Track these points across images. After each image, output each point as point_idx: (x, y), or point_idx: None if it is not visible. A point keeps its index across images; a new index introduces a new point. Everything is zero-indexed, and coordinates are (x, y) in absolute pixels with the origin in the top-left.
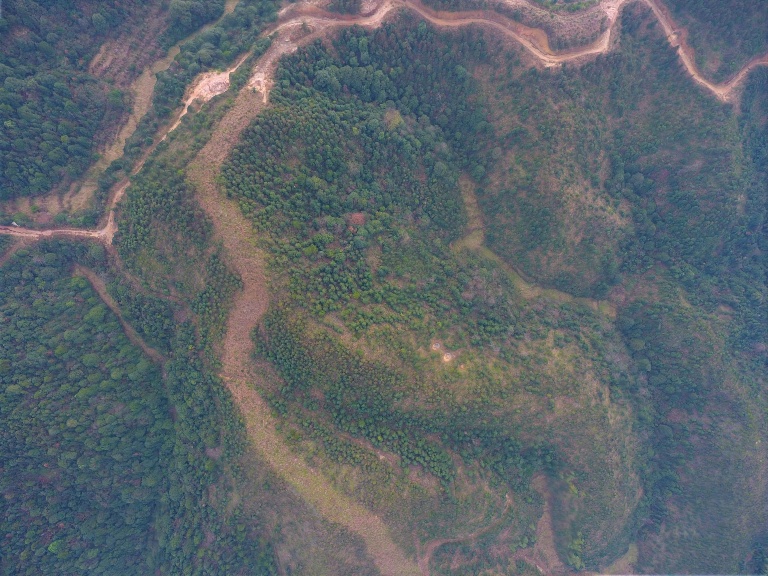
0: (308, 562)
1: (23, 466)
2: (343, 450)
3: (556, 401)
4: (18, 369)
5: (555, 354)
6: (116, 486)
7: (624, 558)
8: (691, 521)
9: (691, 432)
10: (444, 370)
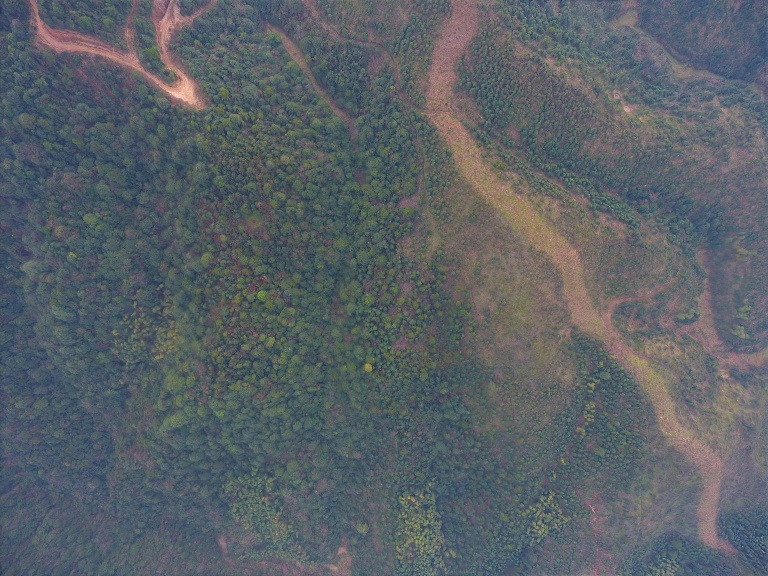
0: (512, 296)
1: (236, 207)
2: (544, 182)
3: (731, 153)
4: (237, 101)
5: (724, 112)
6: (314, 242)
7: None
8: None
9: None
10: (628, 116)
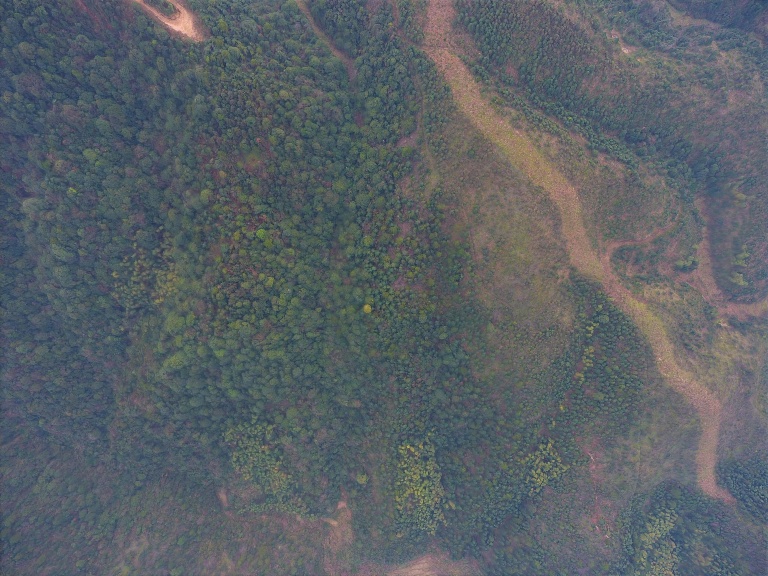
0: (511, 233)
1: (235, 143)
2: (542, 118)
3: (729, 95)
4: (235, 34)
5: (722, 55)
6: (313, 182)
7: None
8: None
9: None
10: (626, 56)
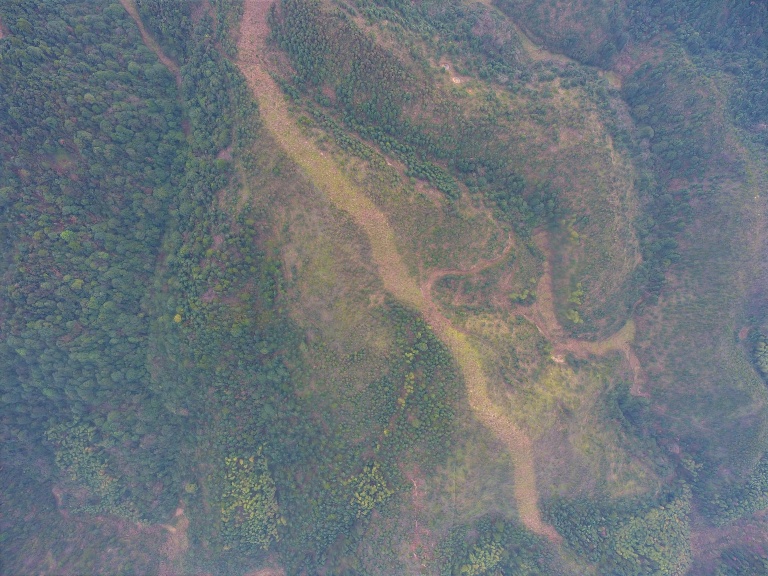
0: (314, 254)
1: (40, 143)
2: (352, 142)
3: (561, 133)
4: (39, 34)
5: (561, 93)
6: (128, 187)
7: (621, 335)
8: (688, 286)
9: (691, 196)
10: (453, 86)
